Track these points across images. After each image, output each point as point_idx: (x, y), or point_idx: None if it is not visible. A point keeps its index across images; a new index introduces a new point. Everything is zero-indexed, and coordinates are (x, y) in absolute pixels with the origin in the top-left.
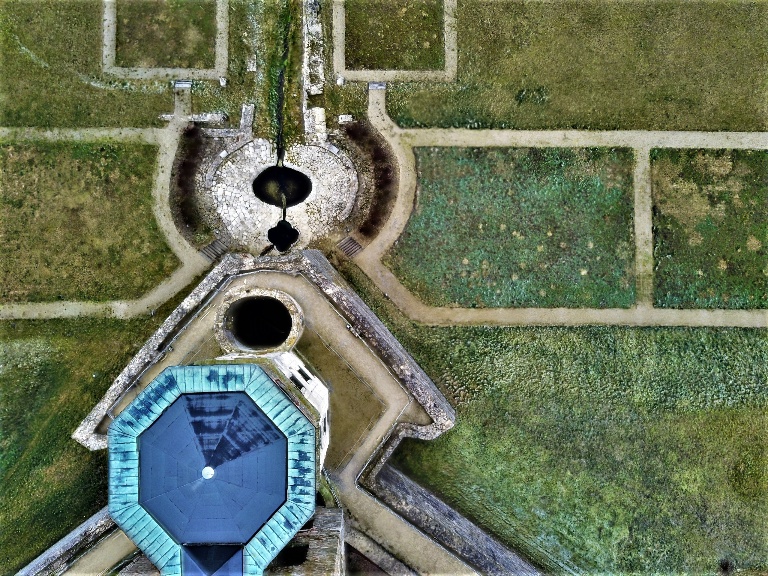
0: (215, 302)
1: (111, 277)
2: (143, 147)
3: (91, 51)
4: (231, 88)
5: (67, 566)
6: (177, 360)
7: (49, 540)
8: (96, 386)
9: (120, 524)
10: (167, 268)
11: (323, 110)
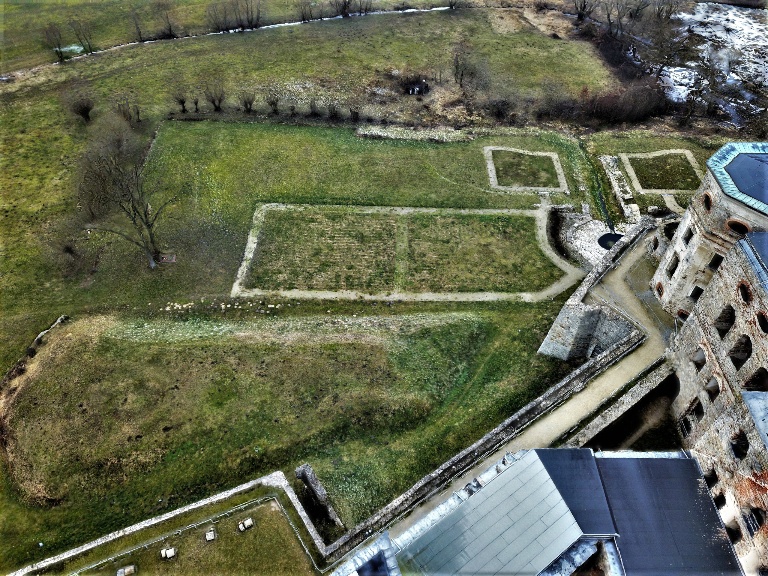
0: (639, 244)
1: (517, 279)
2: (525, 218)
3: (482, 179)
4: (572, 196)
5: (589, 378)
6: (625, 270)
7: None
8: (523, 336)
9: (735, 197)
10: (556, 275)
11: (636, 205)
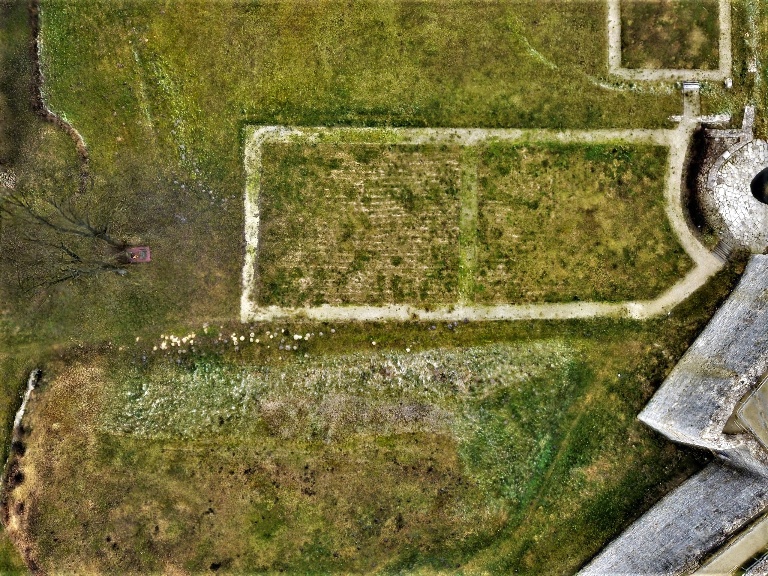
0: None
1: (626, 277)
2: (654, 148)
3: (597, 52)
4: (734, 89)
5: (709, 563)
6: None
7: (605, 537)
8: (623, 385)
9: None
10: (681, 268)
11: None
